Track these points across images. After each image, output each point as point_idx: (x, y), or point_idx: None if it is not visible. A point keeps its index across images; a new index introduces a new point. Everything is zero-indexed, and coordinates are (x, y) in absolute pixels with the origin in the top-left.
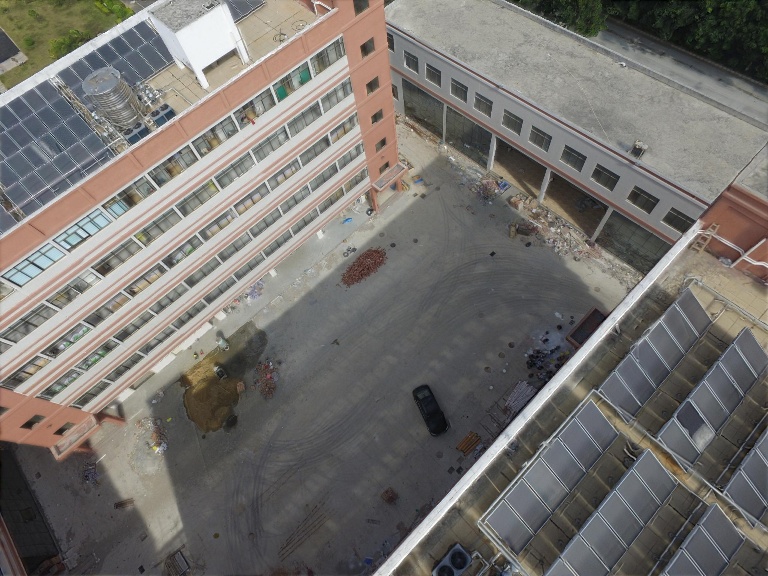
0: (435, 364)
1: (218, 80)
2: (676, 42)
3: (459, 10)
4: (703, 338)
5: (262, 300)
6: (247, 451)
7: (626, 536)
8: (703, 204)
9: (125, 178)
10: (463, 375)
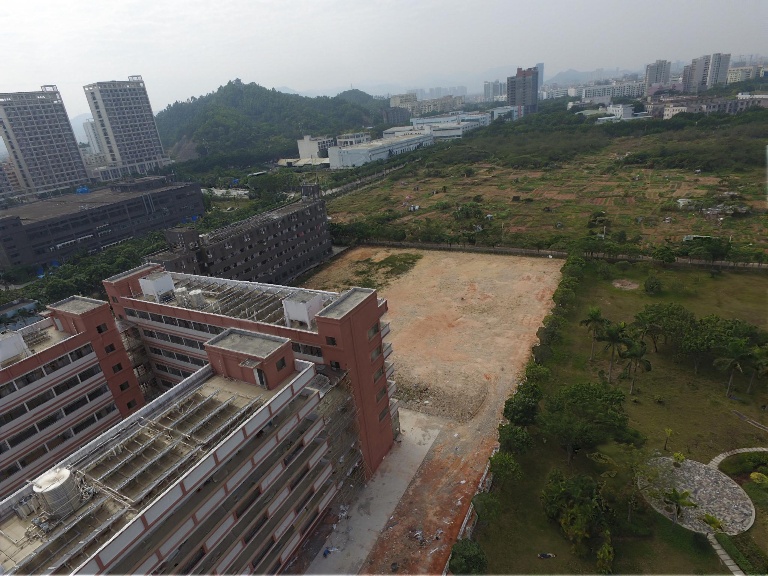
0: None
1: None
2: None
3: None
4: None
5: None
6: None
7: None
8: None
9: None
10: None
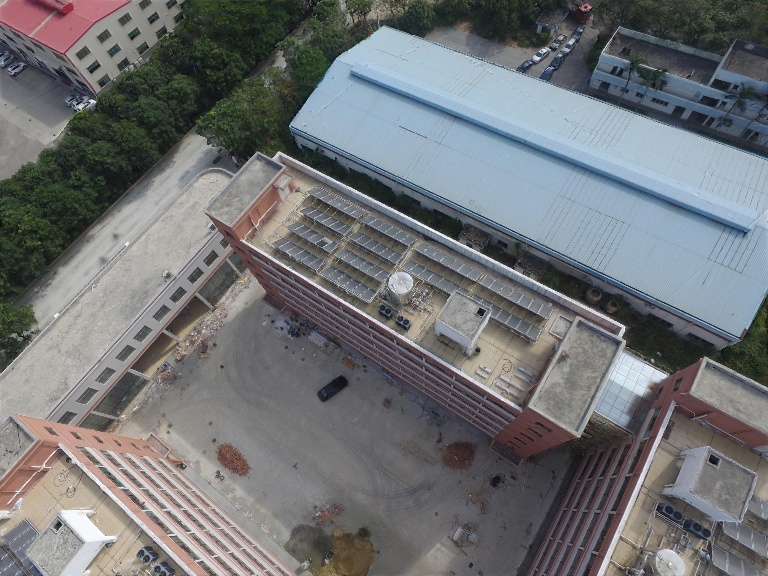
0: (303, 392)
1: (109, 530)
2: (47, 265)
3: (5, 404)
4: (290, 241)
5: (265, 542)
6: (381, 511)
7: (364, 261)
8: (205, 247)
9: (200, 571)
10: (308, 373)
